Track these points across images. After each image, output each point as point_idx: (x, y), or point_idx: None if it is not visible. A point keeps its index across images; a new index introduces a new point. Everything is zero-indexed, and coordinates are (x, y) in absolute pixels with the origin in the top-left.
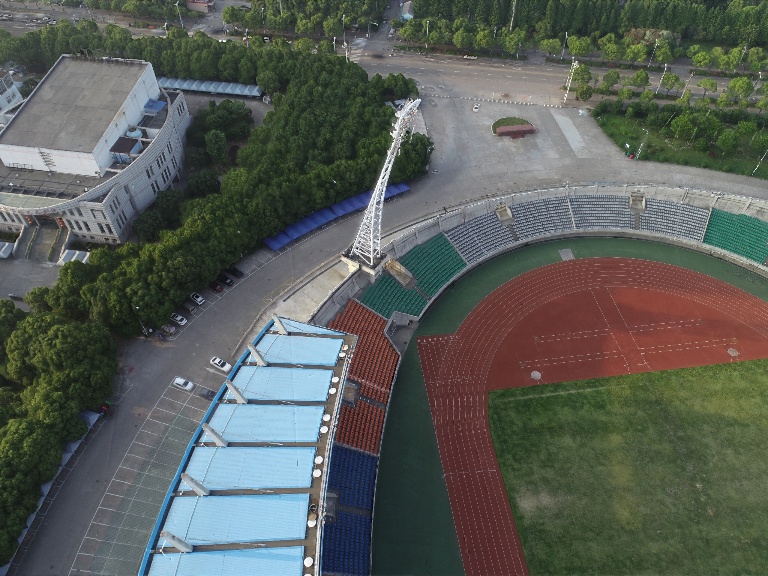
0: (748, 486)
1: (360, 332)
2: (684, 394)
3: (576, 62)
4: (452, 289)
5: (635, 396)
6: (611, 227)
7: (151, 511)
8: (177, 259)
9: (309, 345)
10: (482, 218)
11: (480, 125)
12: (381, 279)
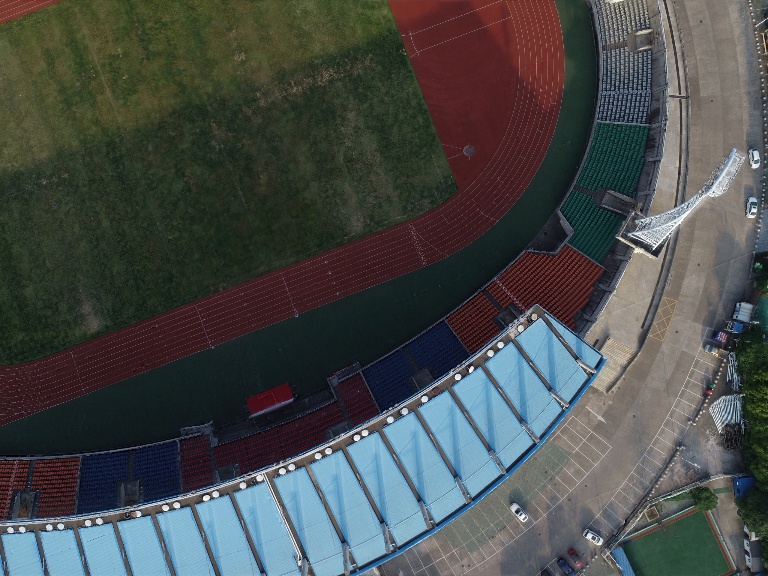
0: (35, 141)
1: None
2: None
3: None
4: None
5: None
6: None
7: None
8: None
9: None
10: None
11: None
12: None
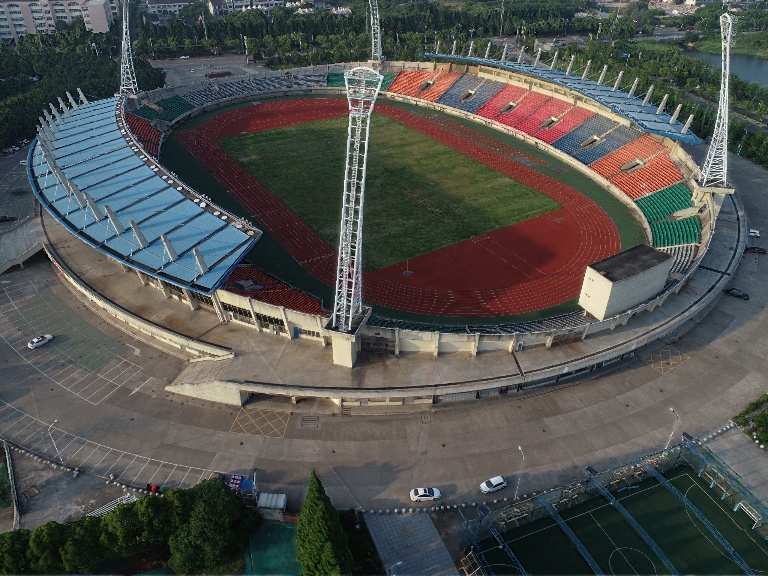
0: None
1: (135, 123)
2: (322, 125)
3: (245, 36)
4: (191, 119)
5: (297, 129)
6: (278, 89)
7: (23, 195)
8: (6, 110)
9: (103, 101)
10: (201, 90)
11: (197, 76)
12: (143, 109)
